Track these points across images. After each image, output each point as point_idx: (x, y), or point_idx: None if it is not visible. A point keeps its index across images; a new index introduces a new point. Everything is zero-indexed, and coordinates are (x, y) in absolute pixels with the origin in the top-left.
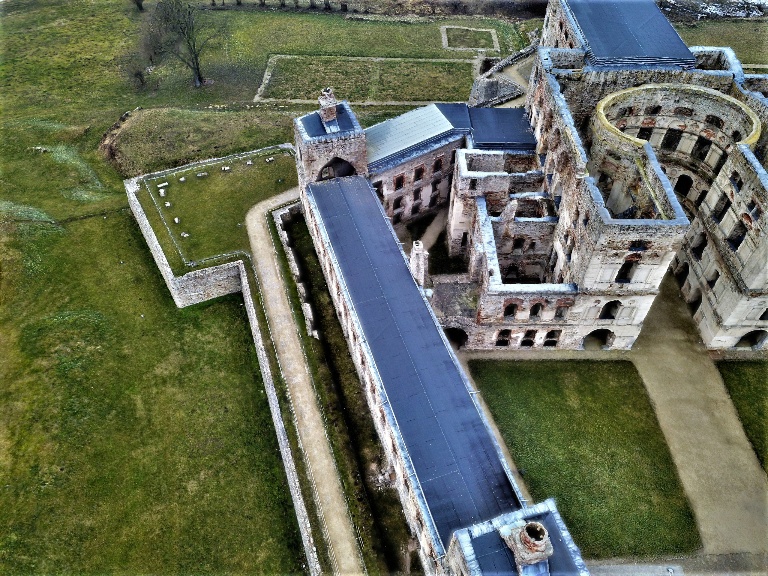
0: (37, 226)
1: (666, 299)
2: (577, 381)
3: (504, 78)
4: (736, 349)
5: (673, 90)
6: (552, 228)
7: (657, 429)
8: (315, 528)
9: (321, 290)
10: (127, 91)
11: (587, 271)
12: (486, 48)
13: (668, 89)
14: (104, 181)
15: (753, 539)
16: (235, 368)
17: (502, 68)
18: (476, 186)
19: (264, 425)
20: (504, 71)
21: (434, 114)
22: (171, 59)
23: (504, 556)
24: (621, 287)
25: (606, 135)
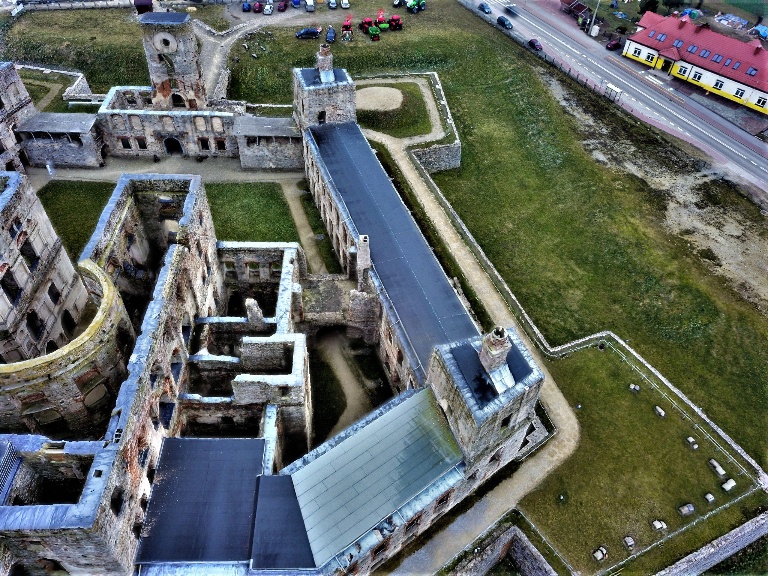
0: None
1: None
2: None
3: None
4: None
5: None
6: None
7: None
8: (424, 174)
9: None
10: None
11: None
12: None
13: None
14: None
15: None
16: (515, 295)
17: None
18: None
19: None
20: None
21: (320, 522)
22: None
23: None
24: None
25: None
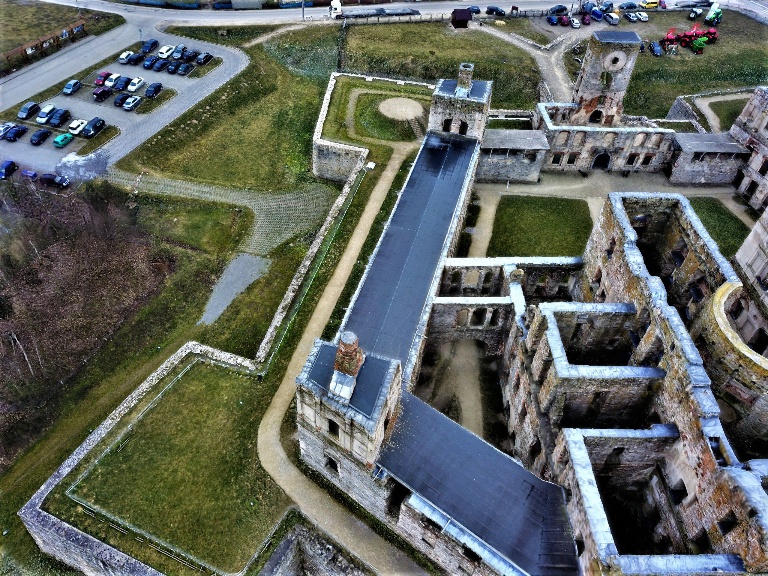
0: None
1: None
2: None
3: None
4: None
5: None
6: None
7: None
8: None
9: None
10: None
11: None
12: None
13: None
14: None
15: None
16: None
17: None
18: None
19: None
20: None
21: None
22: None
23: None
24: None
25: None
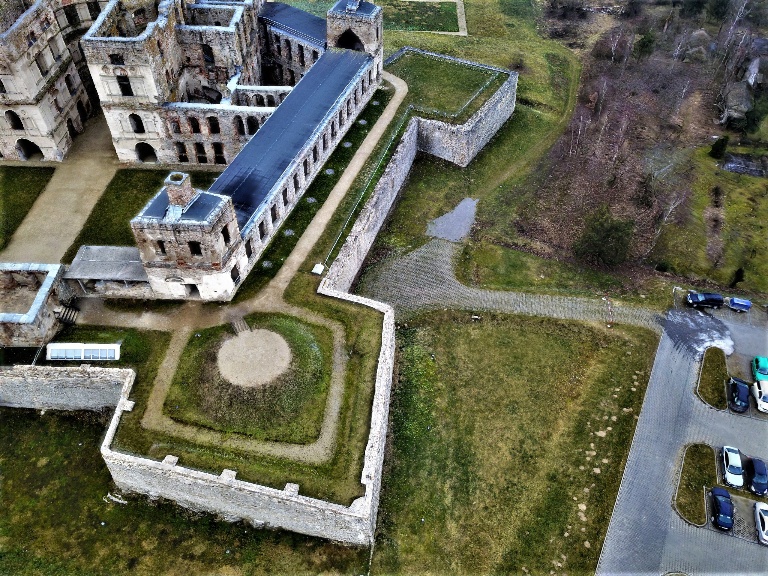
0: None
1: None
2: (1, 177)
3: None
4: (142, 162)
5: None
6: None
7: (30, 203)
8: None
9: None
10: None
11: None
12: None
13: None
14: None
15: (33, 259)
16: None
17: None
18: None
19: None
20: None
21: None
22: None
23: None
24: (4, 97)
25: None
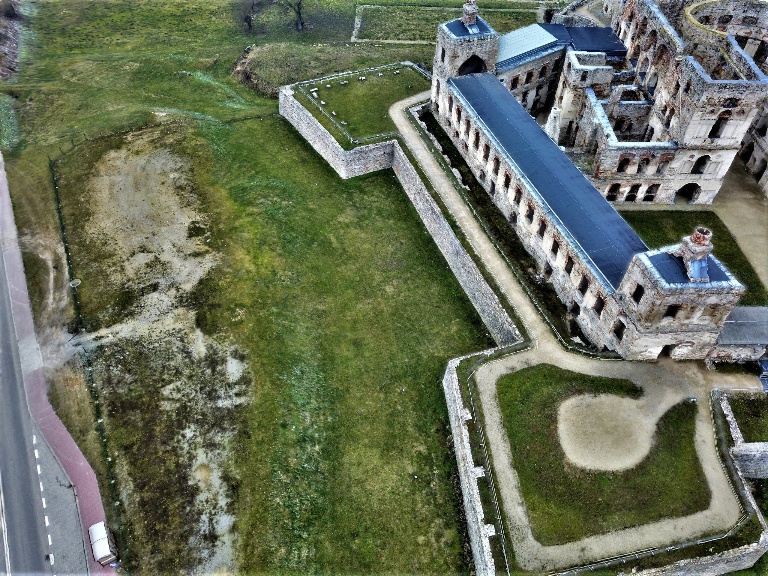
0: (210, 123)
1: (735, 172)
2: (673, 223)
3: (578, 14)
4: None
5: (743, 1)
6: (648, 109)
7: (739, 252)
8: (501, 299)
9: (460, 163)
10: (237, 33)
11: (688, 127)
12: (546, 1)
13: (739, 0)
14: (245, 97)
15: None
16: (400, 218)
17: (574, 8)
18: (586, 78)
19: (433, 253)
20: (576, 10)
21: (539, 30)
22: (269, 8)
23: (674, 263)
24: (712, 142)
25: (695, 31)
